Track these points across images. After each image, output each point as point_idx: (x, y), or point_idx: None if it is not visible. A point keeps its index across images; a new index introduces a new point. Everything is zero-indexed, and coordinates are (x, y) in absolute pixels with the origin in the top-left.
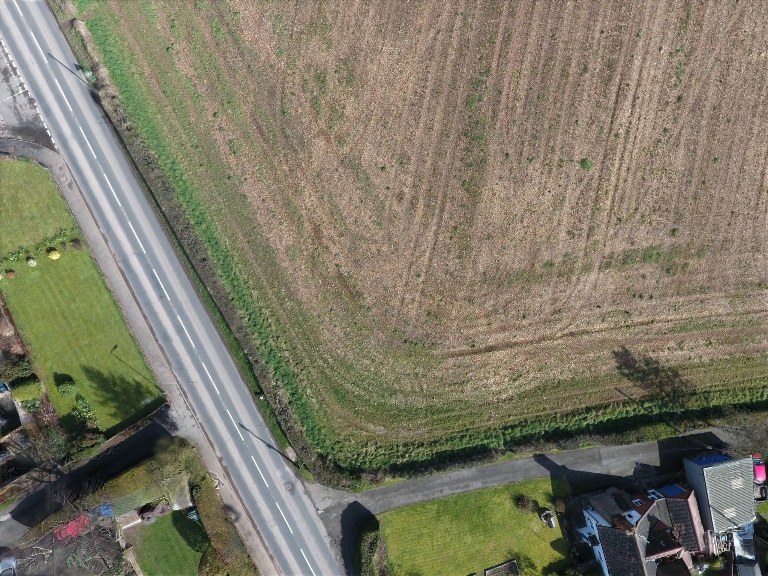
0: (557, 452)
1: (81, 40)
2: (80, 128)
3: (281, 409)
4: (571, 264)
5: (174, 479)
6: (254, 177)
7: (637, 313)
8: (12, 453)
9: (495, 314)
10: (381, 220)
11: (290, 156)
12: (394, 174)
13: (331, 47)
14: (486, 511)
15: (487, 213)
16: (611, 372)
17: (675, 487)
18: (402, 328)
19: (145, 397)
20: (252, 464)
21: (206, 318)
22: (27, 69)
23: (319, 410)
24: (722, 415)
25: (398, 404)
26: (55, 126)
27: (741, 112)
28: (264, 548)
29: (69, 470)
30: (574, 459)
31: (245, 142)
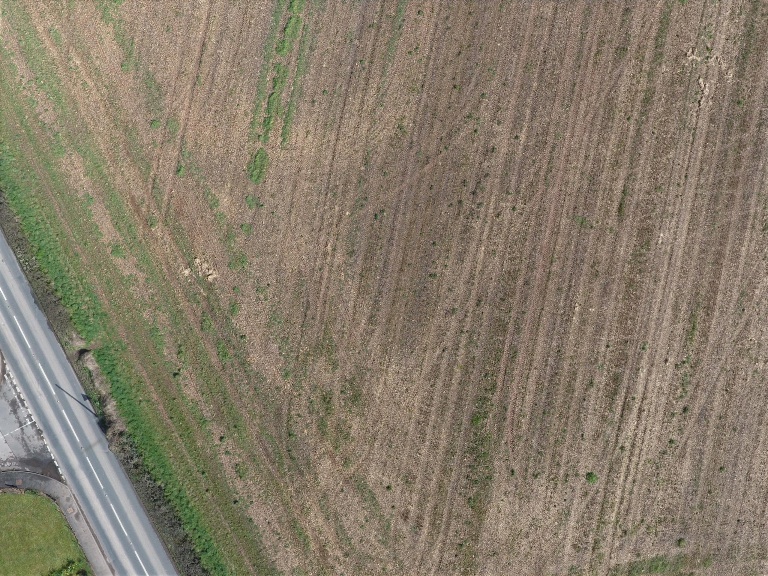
0: None
1: (88, 372)
2: (87, 458)
3: None
4: None
5: None
6: (260, 500)
7: None
8: None
9: None
10: (386, 539)
11: (296, 477)
12: (399, 493)
13: (337, 368)
14: None
15: (492, 529)
16: None
17: None
18: None
19: None
20: None
21: None
22: (35, 401)
23: None
24: None
25: None
26: (62, 457)
27: (747, 420)
28: None
29: None
30: None
31: (251, 465)
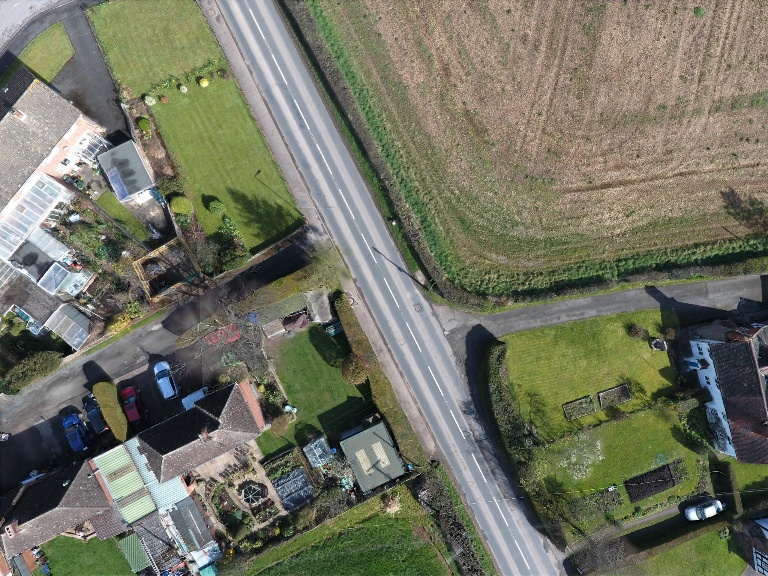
0: (667, 285)
1: None
2: None
3: (413, 233)
4: (683, 107)
5: (316, 292)
6: (388, 16)
7: (744, 156)
8: (163, 268)
9: (611, 153)
10: (506, 60)
11: None
12: (518, 17)
13: None
14: (600, 338)
15: (605, 56)
16: (718, 211)
17: None
18: (524, 164)
19: (286, 219)
20: (384, 285)
21: (343, 147)
22: None
23: (446, 238)
24: None
25: (519, 235)
26: None
27: None
28: (394, 364)
29: (215, 285)
30: (682, 292)
31: None
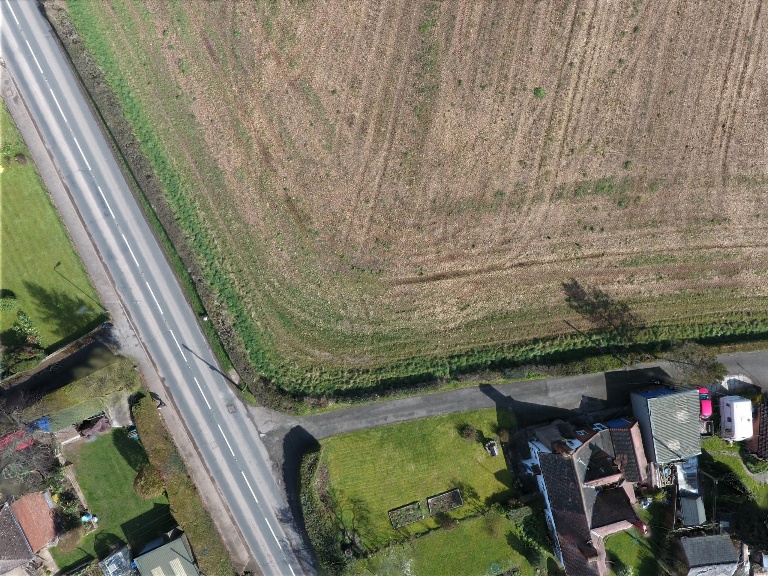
0: (503, 383)
1: None
2: (27, 42)
3: (224, 330)
4: (522, 194)
5: (114, 396)
6: (203, 97)
7: (588, 245)
8: None
9: (444, 242)
10: (331, 144)
11: (240, 77)
12: (345, 98)
13: None
14: (430, 439)
15: (438, 140)
16: (560, 304)
17: (621, 420)
18: (350, 254)
19: (88, 315)
20: (195, 385)
21: (151, 237)
22: None
23: (264, 334)
24: (670, 349)
25: (344, 330)
26: (1, 39)
27: (698, 45)
28: (205, 470)
29: (9, 386)
30: (520, 390)
31: (194, 61)
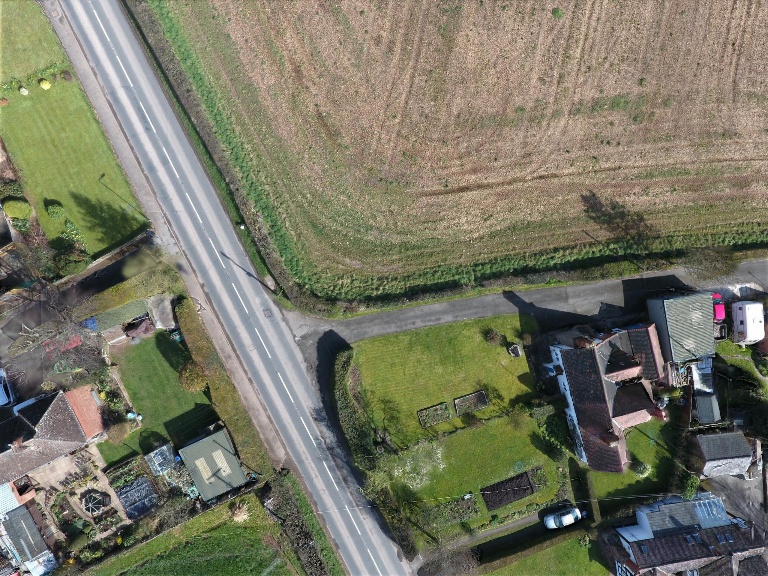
0: (525, 289)
1: None
2: None
3: (261, 238)
4: (542, 110)
5: (157, 298)
6: (238, 18)
7: (605, 159)
8: (4, 273)
9: (468, 156)
10: (359, 62)
11: None
12: (372, 18)
13: None
14: (456, 343)
15: (461, 58)
16: (579, 215)
17: (638, 325)
18: (378, 167)
19: (131, 224)
20: (233, 291)
21: (190, 150)
22: None
23: (297, 242)
24: (684, 256)
25: (373, 240)
26: None
27: None
28: (243, 371)
29: (58, 291)
30: (542, 297)
31: None
